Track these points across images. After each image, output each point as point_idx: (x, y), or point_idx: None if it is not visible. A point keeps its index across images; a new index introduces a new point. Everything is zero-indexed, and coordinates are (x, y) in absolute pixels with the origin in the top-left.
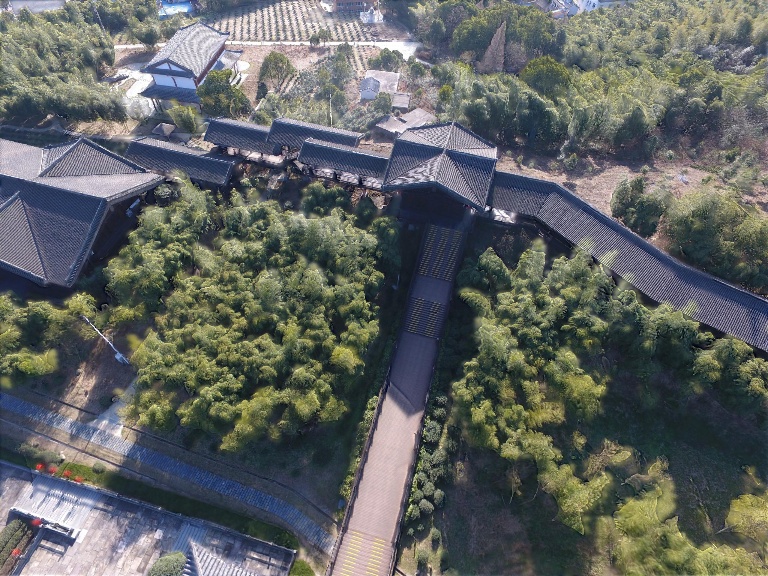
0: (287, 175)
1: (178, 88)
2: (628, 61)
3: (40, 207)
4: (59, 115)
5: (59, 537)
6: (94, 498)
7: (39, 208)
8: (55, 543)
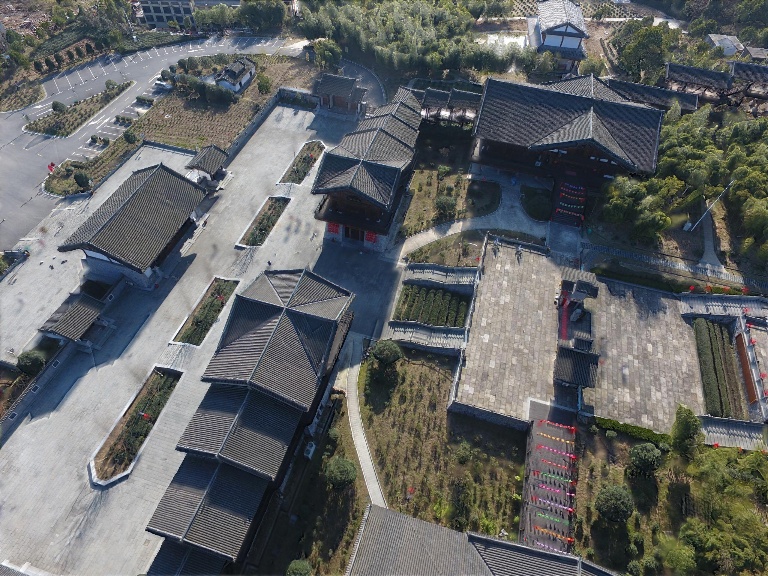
0: (713, 109)
1: (562, 48)
2: None
3: (612, 118)
4: (476, 68)
5: (755, 323)
6: (757, 303)
7: (611, 119)
8: (756, 326)
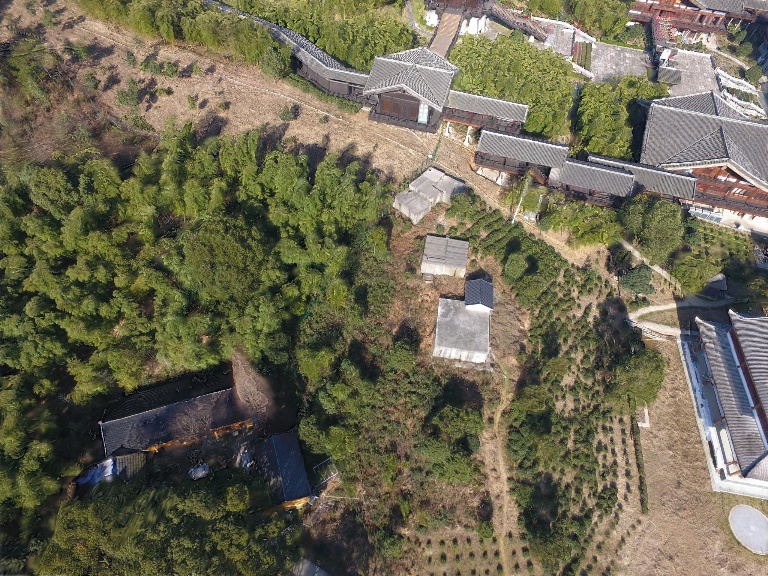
0: None
1: None
2: (6, 346)
3: None
4: None
5: None
6: None
7: None
8: None
